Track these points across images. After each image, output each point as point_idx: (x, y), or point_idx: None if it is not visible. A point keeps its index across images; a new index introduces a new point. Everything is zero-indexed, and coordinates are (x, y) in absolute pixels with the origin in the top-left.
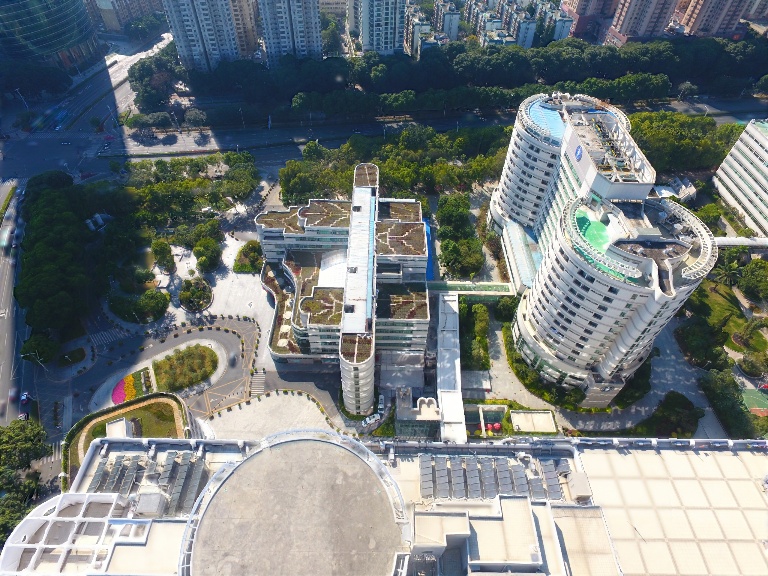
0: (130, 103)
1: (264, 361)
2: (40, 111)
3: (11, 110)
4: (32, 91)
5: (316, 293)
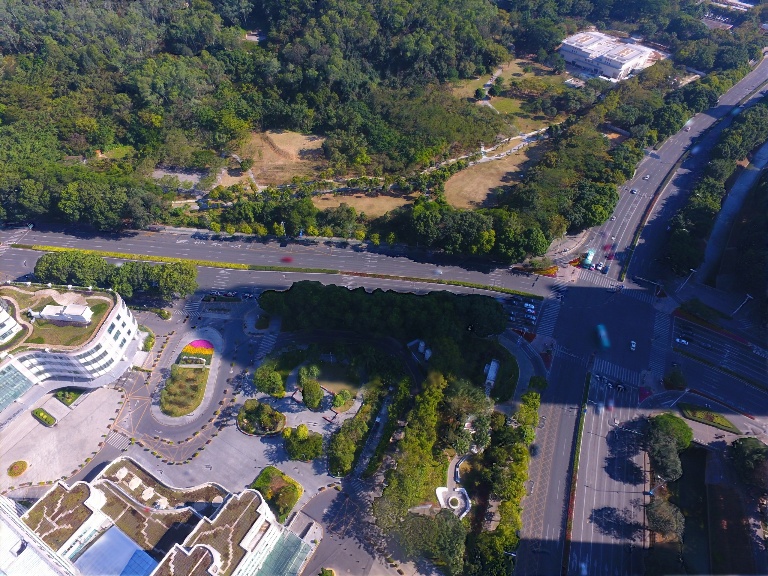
0: (765, 436)
1: (134, 454)
2: (736, 326)
3: (741, 300)
4: (767, 314)
5: (86, 511)
